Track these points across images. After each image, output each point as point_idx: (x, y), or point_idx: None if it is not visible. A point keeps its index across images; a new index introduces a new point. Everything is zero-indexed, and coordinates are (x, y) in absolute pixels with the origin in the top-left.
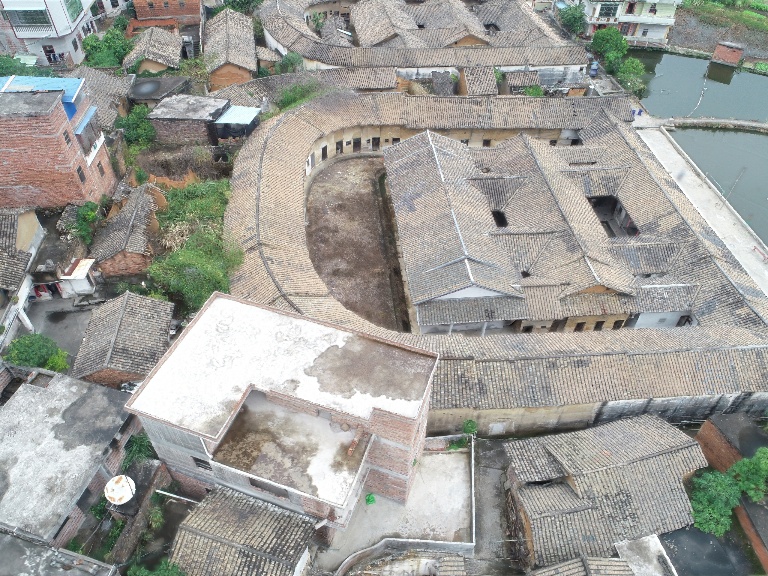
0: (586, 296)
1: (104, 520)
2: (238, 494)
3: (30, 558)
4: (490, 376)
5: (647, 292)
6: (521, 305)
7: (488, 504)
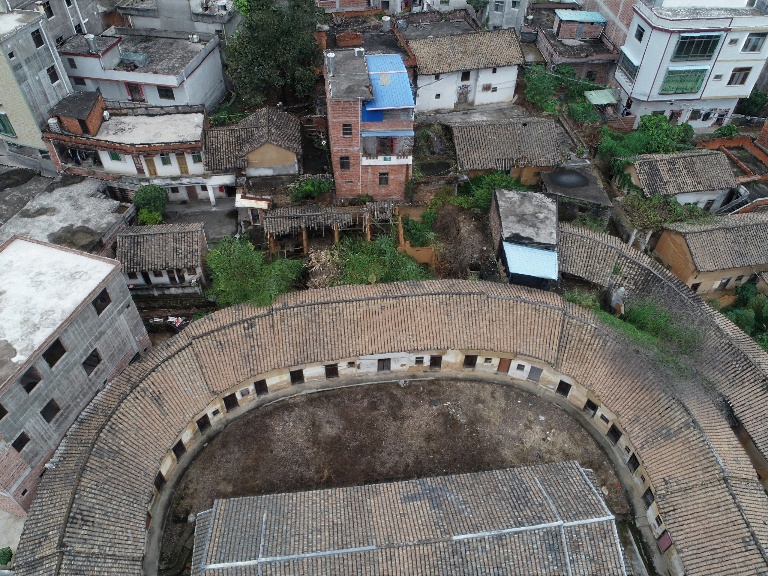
0: None
1: None
2: None
3: None
4: None
5: None
6: None
7: None
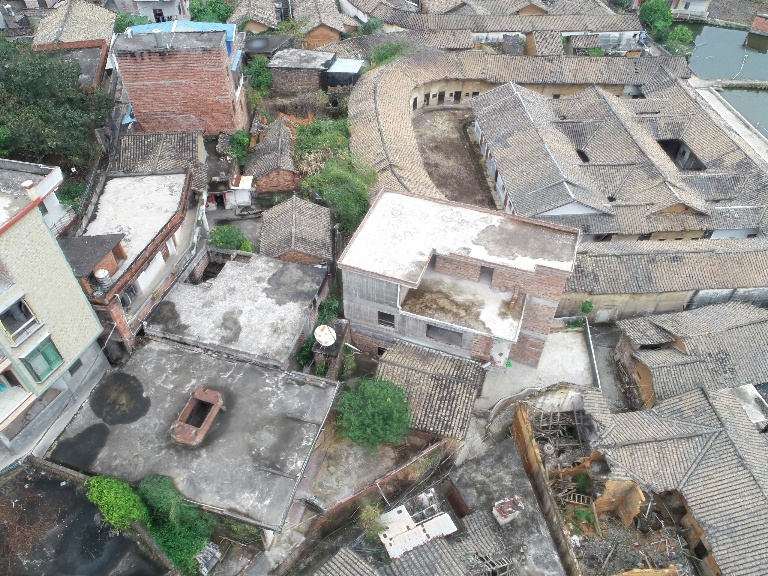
0: (668, 215)
1: (305, 366)
2: (414, 345)
3: (269, 378)
4: (601, 268)
5: (720, 212)
6: (612, 221)
7: (603, 371)
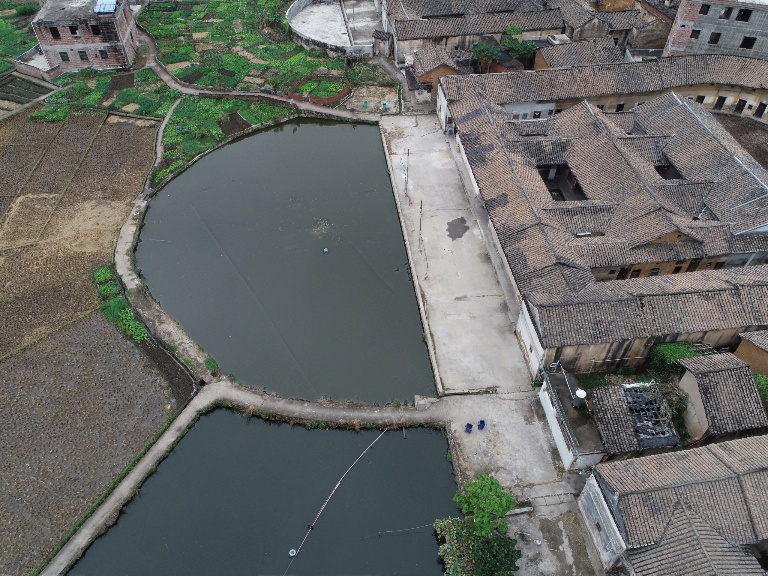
0: None
1: None
2: None
3: None
4: None
5: None
6: None
7: None
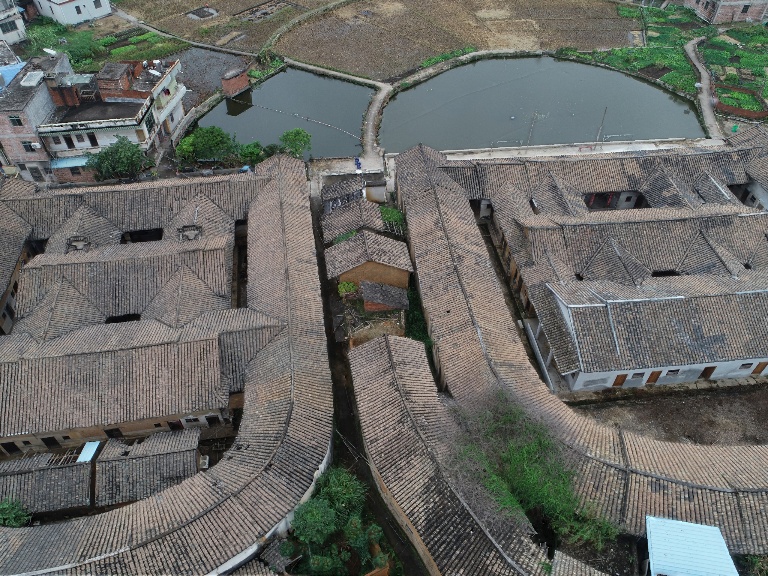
0: None
1: None
2: None
3: None
4: None
5: None
6: None
7: None
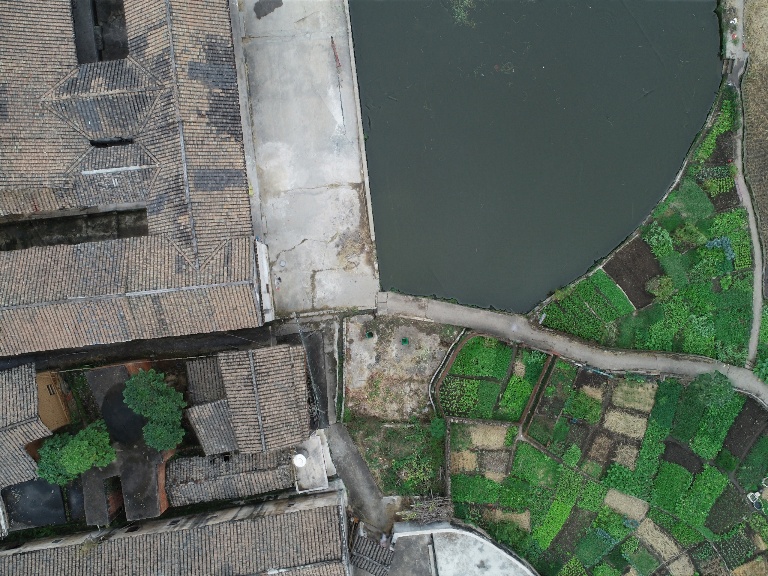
0: (8, 190)
1: None
2: None
3: None
4: None
5: (90, 180)
6: None
7: None
